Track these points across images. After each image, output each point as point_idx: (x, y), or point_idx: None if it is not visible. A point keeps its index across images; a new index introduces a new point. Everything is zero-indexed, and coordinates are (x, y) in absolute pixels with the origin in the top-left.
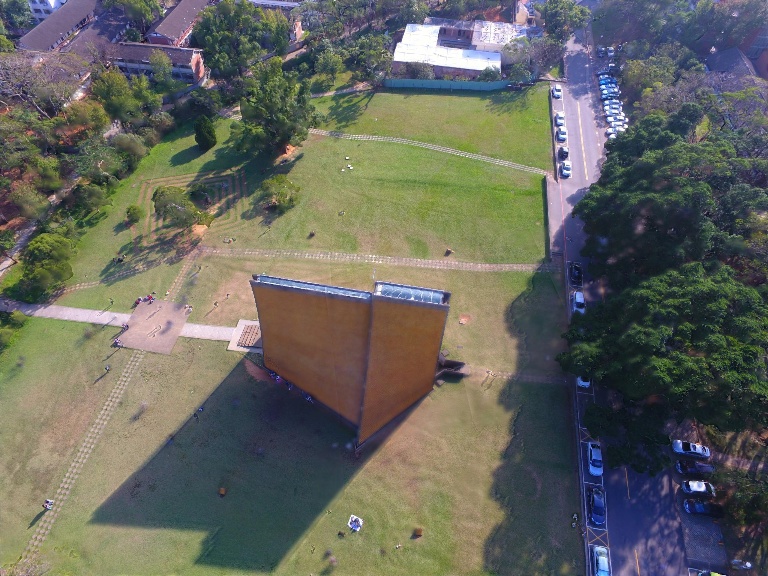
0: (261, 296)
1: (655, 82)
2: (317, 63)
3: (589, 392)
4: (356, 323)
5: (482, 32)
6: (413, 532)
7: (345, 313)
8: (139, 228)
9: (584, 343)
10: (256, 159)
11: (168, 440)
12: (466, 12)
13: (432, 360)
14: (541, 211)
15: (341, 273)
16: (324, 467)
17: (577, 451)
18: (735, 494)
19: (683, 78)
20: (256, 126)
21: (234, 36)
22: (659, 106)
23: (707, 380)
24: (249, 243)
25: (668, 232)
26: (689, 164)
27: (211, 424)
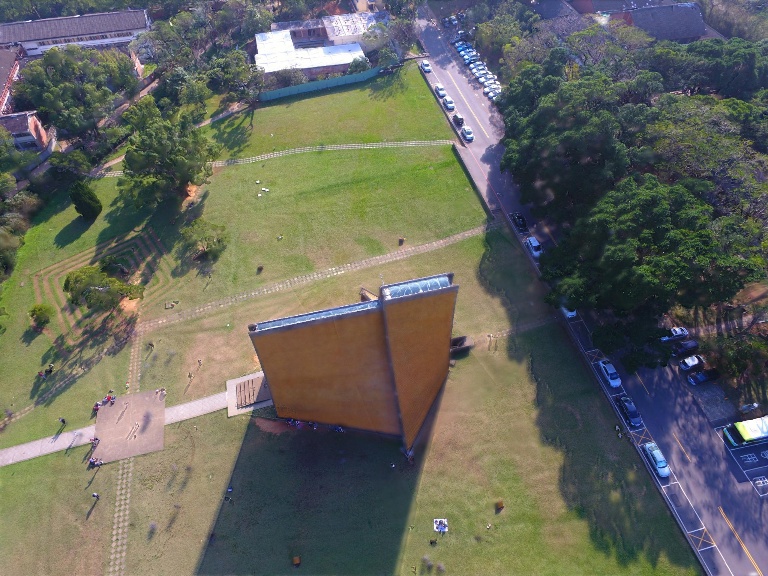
0: (262, 345)
1: (511, 38)
2: (181, 94)
3: (578, 319)
4: (368, 335)
5: (334, 27)
6: (495, 507)
7: (355, 330)
8: (54, 328)
9: (565, 278)
10: (158, 211)
11: (209, 538)
12: (307, 11)
13: (446, 343)
14: (464, 177)
15: (309, 296)
16: (386, 488)
17: (593, 373)
18: (728, 354)
19: (535, 28)
20: (145, 176)
21: (76, 86)
22: (525, 57)
23: (685, 270)
24: (195, 300)
25: (586, 161)
26: (586, 98)
27: (249, 500)
